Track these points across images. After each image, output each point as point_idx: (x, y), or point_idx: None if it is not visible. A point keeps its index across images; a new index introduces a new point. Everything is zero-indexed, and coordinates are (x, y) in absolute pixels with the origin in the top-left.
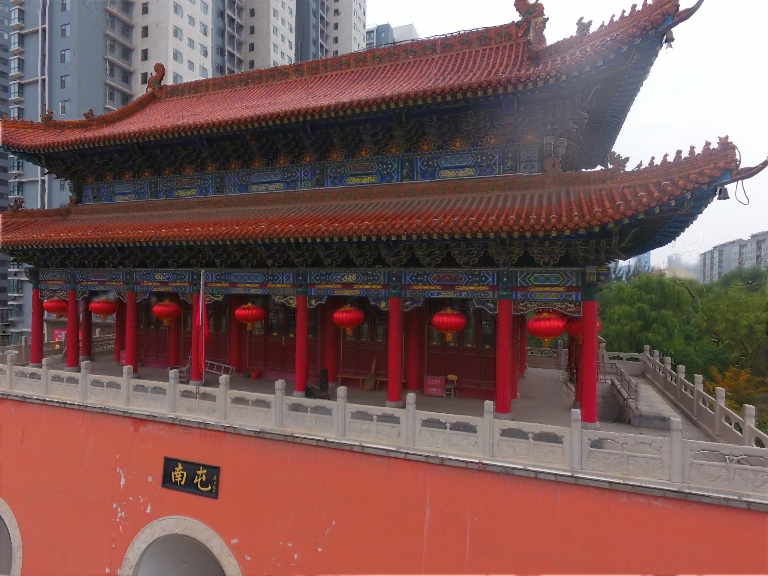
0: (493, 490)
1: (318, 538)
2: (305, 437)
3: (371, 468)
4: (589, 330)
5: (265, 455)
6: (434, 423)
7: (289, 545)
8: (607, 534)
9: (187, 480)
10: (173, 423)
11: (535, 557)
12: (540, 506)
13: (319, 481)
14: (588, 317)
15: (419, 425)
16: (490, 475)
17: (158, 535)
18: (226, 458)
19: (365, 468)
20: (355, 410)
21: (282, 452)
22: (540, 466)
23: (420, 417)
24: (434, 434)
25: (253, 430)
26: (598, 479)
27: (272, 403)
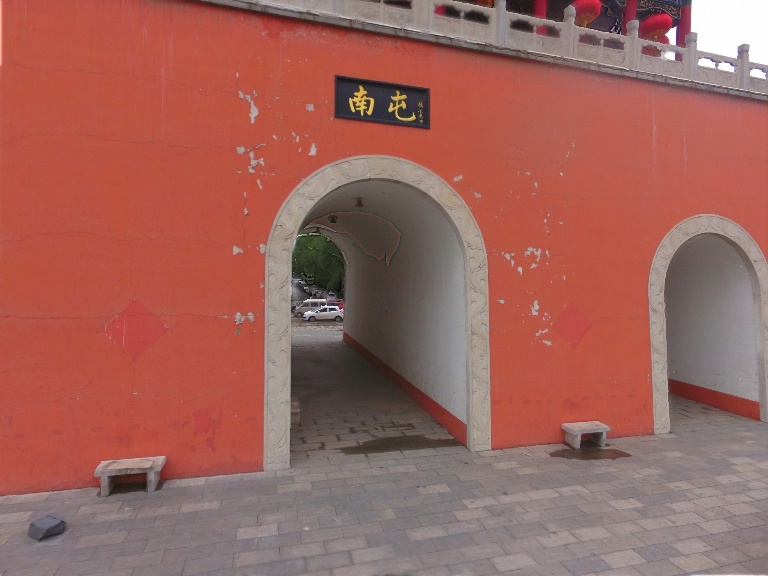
0: (699, 106)
1: (559, 162)
2: (541, 53)
3: (605, 89)
4: (688, 28)
5: (490, 75)
6: (651, 51)
7: (528, 173)
8: (766, 134)
9: (376, 109)
10: (351, 26)
11: (728, 156)
12: (729, 117)
13: (555, 103)
14: (687, 18)
15: (640, 51)
16: (696, 94)
17: (337, 184)
18: (438, 78)
19: (599, 89)
20: (584, 32)
21: (511, 72)
22: (728, 86)
23: (642, 43)
24: (652, 60)
25: (476, 42)
26: (762, 93)
27: (492, 17)
